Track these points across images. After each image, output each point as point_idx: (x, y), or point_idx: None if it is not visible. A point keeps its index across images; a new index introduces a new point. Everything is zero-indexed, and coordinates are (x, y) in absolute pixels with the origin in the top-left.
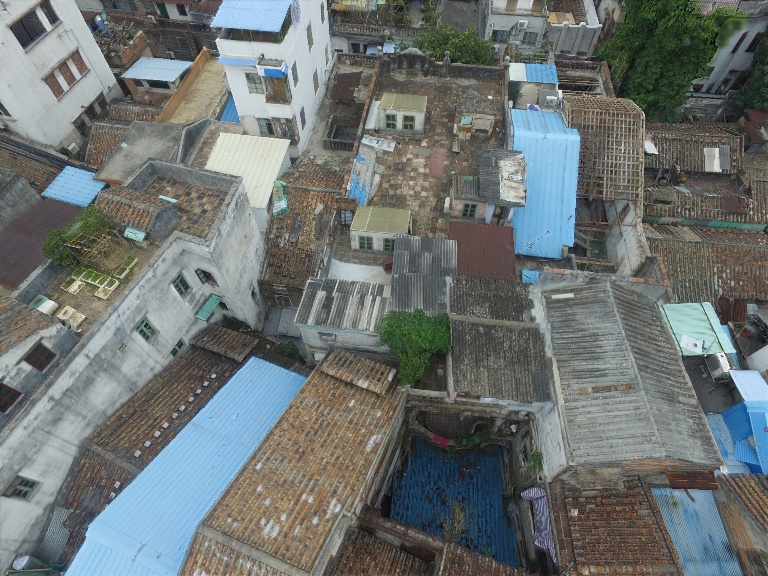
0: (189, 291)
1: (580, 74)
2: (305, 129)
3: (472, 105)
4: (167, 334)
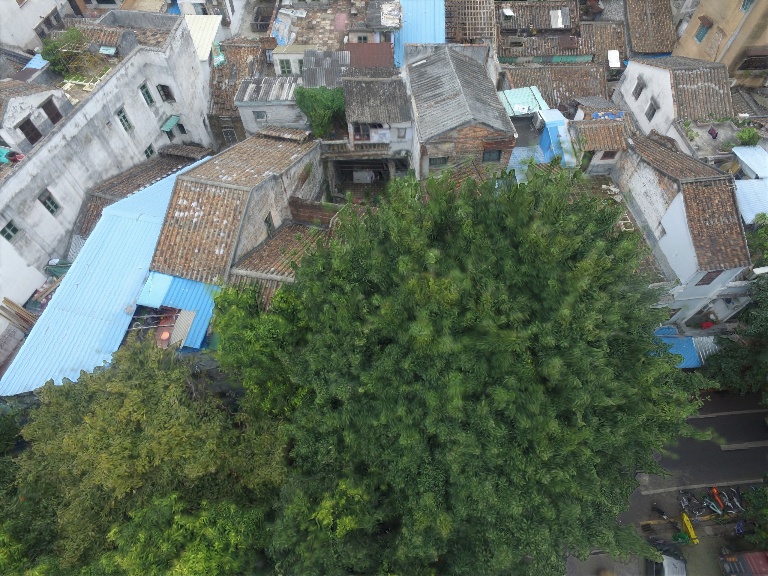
0: (153, 104)
1: None
2: (235, 16)
3: None
4: (140, 133)
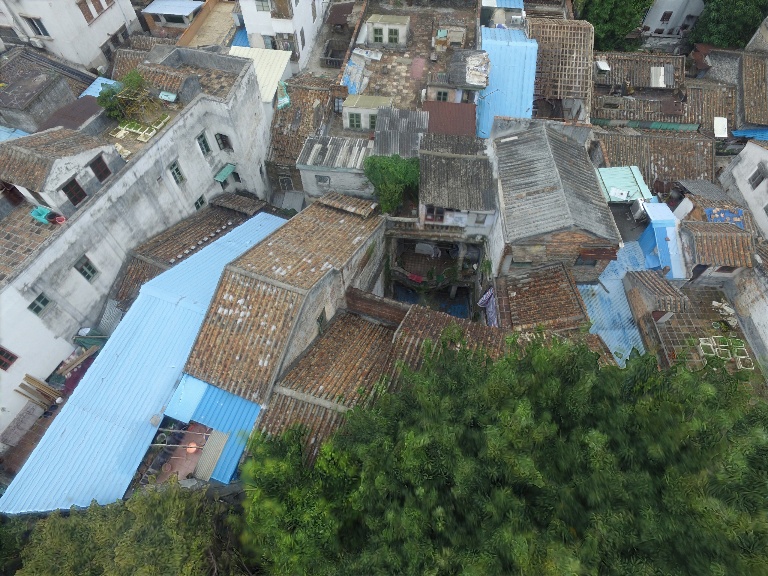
0: (210, 153)
1: (547, 9)
2: (304, 50)
3: (447, 21)
4: (192, 185)
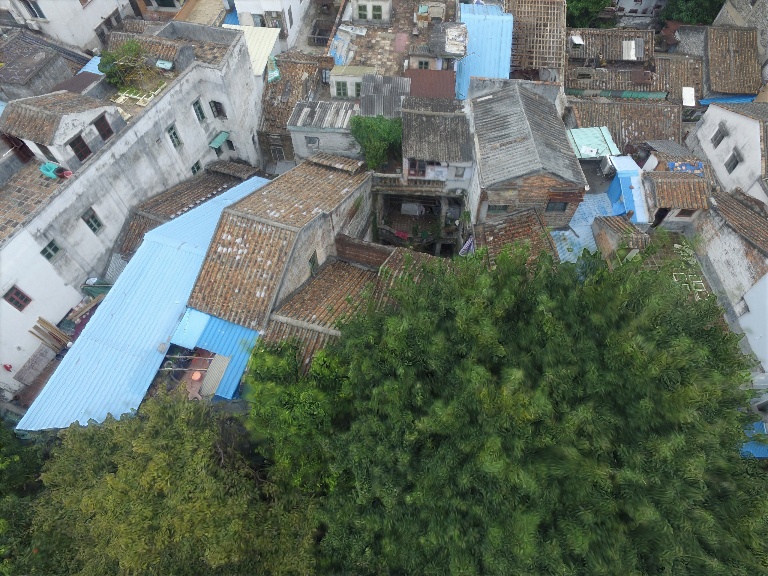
0: (205, 120)
1: None
2: (292, 29)
3: None
4: (189, 150)
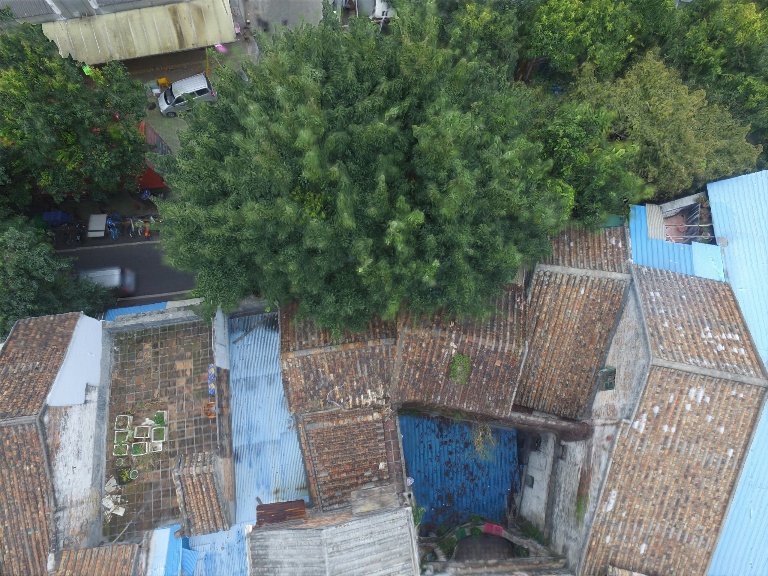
0: None
1: None
2: None
3: None
4: None
